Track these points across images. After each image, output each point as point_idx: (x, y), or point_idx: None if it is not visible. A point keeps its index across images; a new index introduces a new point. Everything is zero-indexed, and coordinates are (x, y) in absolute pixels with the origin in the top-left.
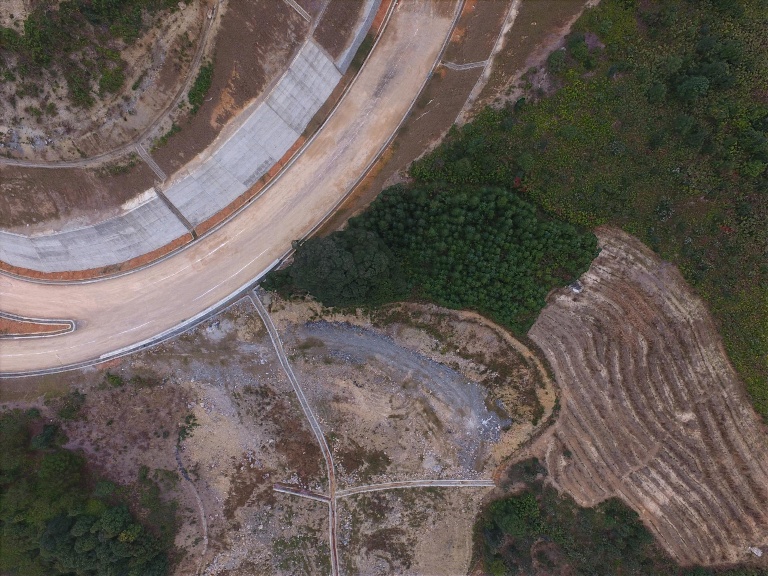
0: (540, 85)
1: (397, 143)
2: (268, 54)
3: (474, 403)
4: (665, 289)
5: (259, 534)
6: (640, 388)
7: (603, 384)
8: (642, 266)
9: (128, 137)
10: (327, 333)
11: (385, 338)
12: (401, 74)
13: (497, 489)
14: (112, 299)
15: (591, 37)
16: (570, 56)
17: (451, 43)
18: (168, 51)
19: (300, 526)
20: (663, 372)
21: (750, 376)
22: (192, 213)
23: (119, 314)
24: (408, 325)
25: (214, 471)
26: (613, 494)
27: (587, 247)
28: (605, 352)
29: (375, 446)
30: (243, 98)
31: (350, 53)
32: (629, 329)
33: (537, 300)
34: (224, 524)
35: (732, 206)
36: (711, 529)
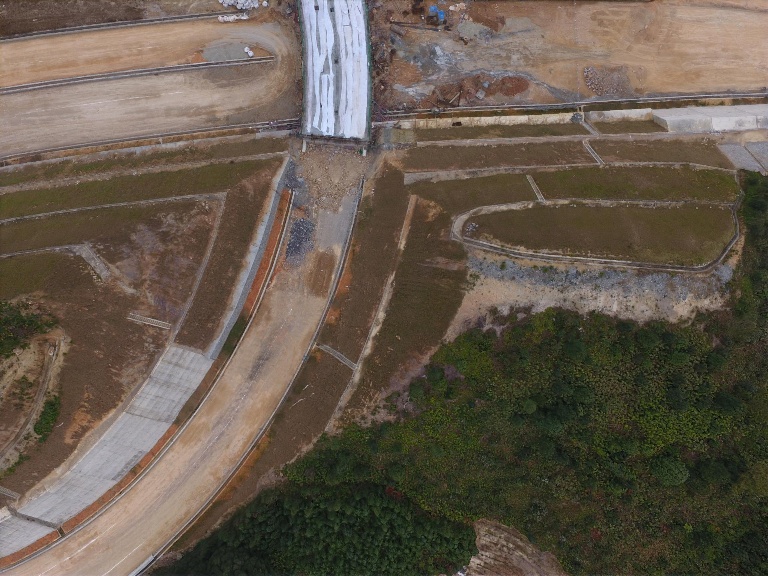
0: (405, 406)
1: (273, 430)
2: (124, 370)
3: None
4: None
5: None
6: None
7: None
8: (523, 554)
9: None
10: None
11: None
12: (276, 356)
13: None
14: None
15: (450, 368)
16: None
17: (326, 325)
18: (5, 396)
19: None
20: None
21: None
22: (56, 516)
23: None
24: None
25: None
26: None
27: (465, 547)
28: None
29: None
30: (100, 411)
31: (220, 341)
32: None
33: None
34: None
35: (600, 514)
36: None
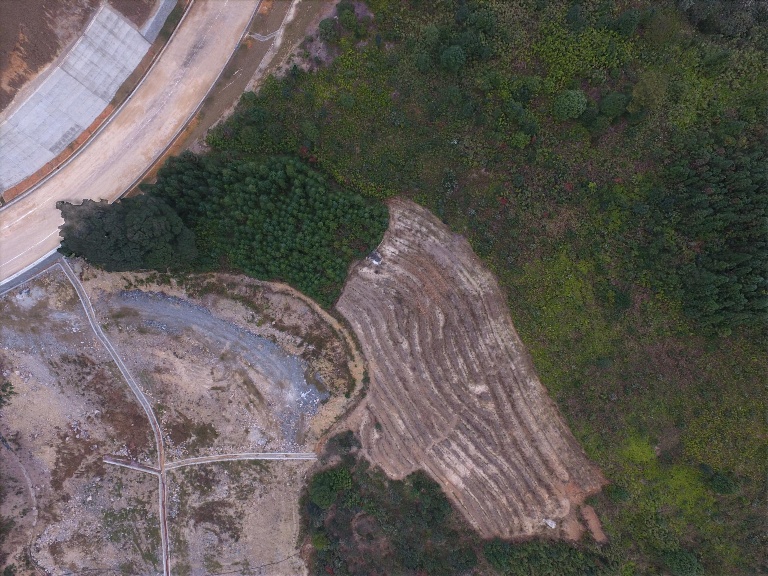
0: (318, 54)
1: (203, 113)
2: (58, 18)
3: (293, 376)
4: (457, 262)
5: (88, 505)
6: (437, 360)
7: (404, 356)
8: (435, 238)
9: None
10: (142, 303)
11: (202, 309)
12: (210, 44)
13: (318, 462)
14: None
15: (360, 6)
16: (341, 25)
17: (258, 14)
18: None
19: (130, 498)
20: (456, 344)
21: (534, 348)
22: None
23: None
24: (223, 296)
25: (38, 441)
26: (419, 466)
27: (375, 218)
28: (405, 324)
29: (202, 419)
30: (36, 62)
31: (156, 22)
32: (427, 301)
33: (336, 271)
34: (52, 495)
35: (508, 178)
36: (509, 501)
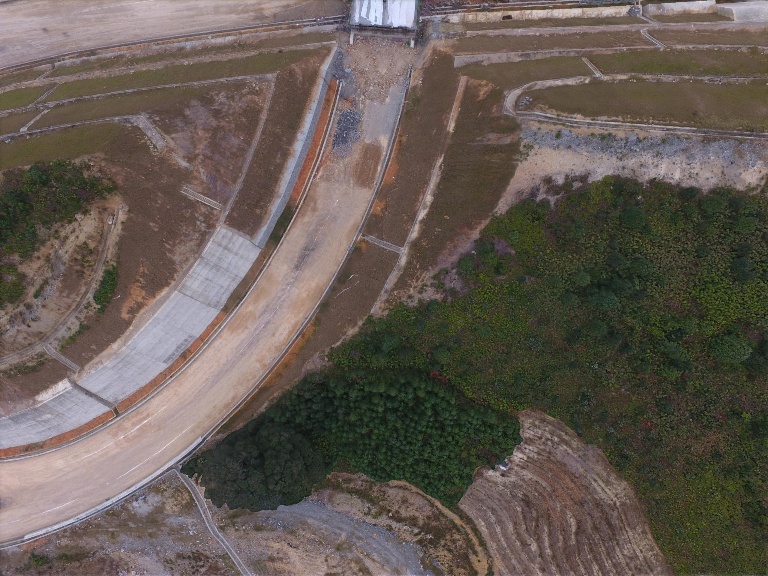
0: (452, 284)
1: (318, 319)
2: (177, 247)
3: (410, 562)
4: (591, 471)
5: None
6: (569, 565)
7: (533, 558)
8: (567, 448)
9: (34, 339)
10: None
11: (317, 503)
12: (322, 246)
13: None
14: (35, 477)
15: (500, 243)
16: (480, 261)
17: (371, 215)
18: (67, 261)
19: None
20: (591, 552)
21: (676, 562)
22: (111, 394)
23: (43, 492)
24: (339, 491)
25: None
26: None
27: (509, 435)
28: (534, 527)
29: None
30: (154, 289)
31: (267, 229)
32: (557, 506)
33: (463, 479)
34: None
35: (652, 402)
36: None
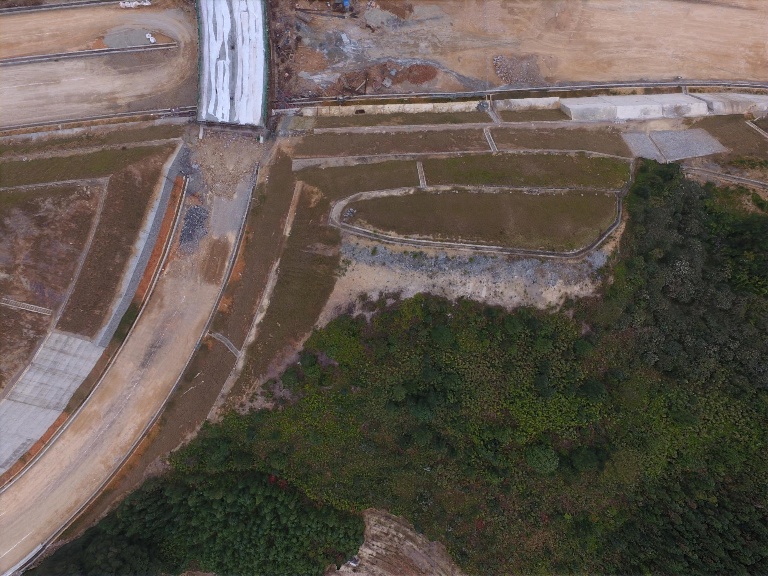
0: (282, 393)
1: (164, 419)
2: (2, 356)
3: None
4: (436, 567)
5: None
6: None
7: None
8: (413, 544)
9: None
10: None
11: None
12: (168, 344)
13: None
14: None
15: (324, 355)
16: None
17: (218, 312)
18: None
19: None
20: None
21: None
22: None
23: None
24: None
25: None
26: None
27: (350, 537)
28: None
29: None
30: None
31: (109, 328)
32: None
33: None
34: None
35: (483, 503)
36: None
